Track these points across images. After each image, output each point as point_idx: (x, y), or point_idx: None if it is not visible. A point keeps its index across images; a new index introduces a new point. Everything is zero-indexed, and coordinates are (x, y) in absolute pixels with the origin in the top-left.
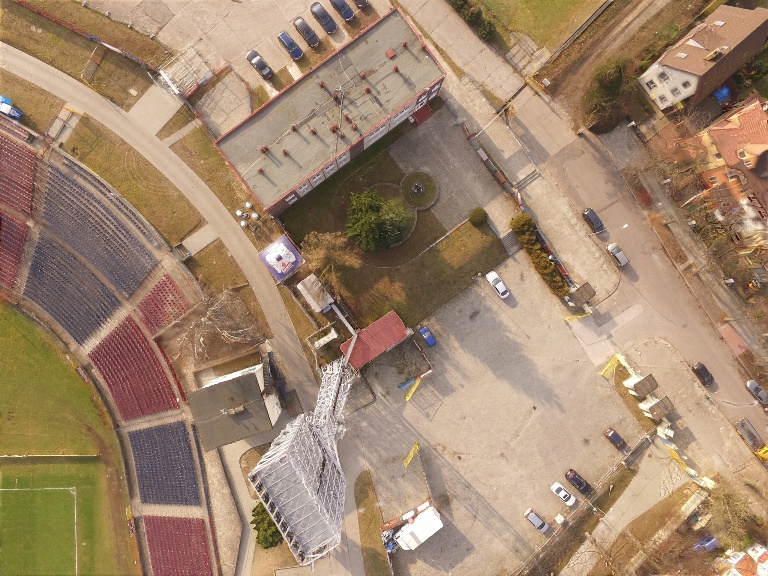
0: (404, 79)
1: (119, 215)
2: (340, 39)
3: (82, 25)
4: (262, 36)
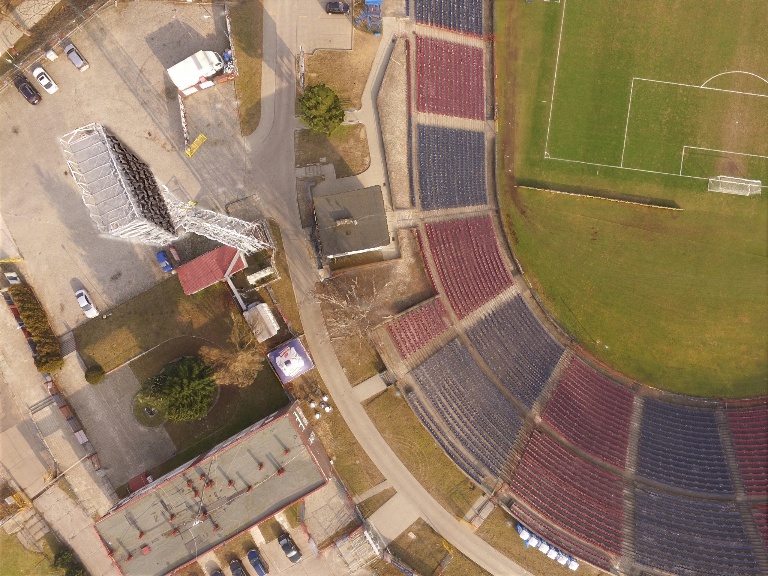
0: (136, 524)
1: (441, 422)
2: (210, 564)
3: None
4: (285, 575)
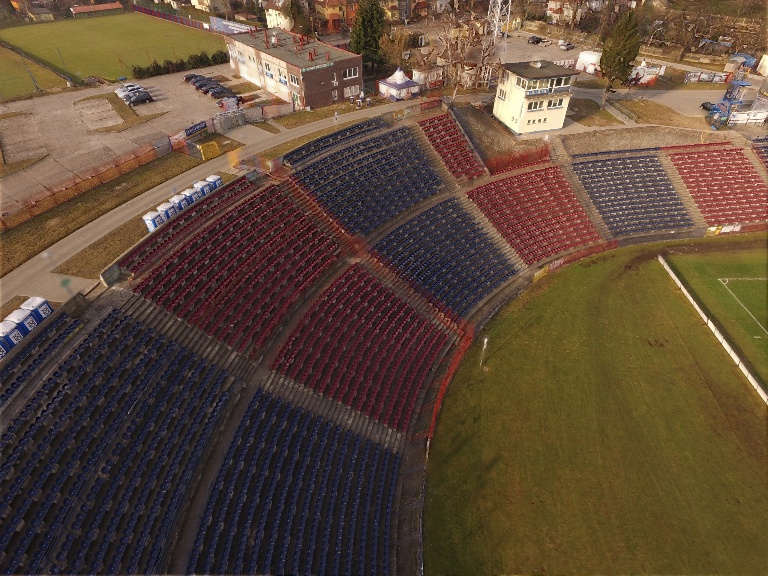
0: None
1: None
2: None
3: (137, 163)
4: None
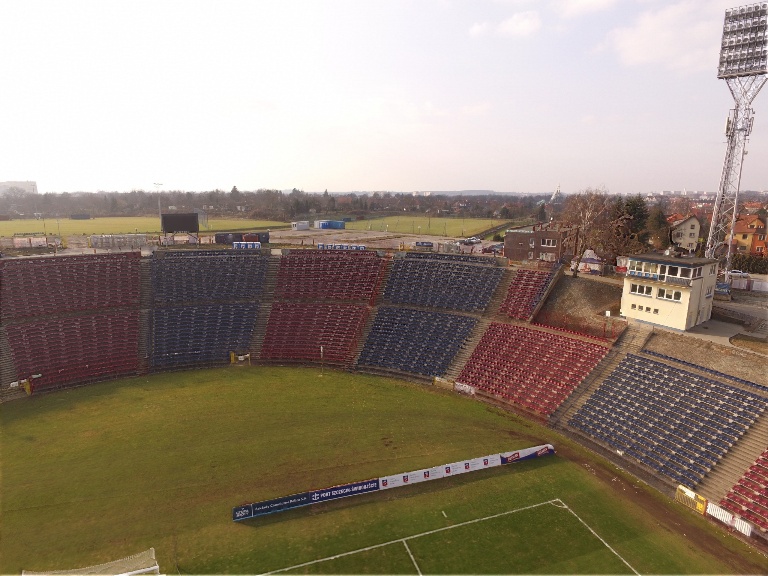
0: None
1: None
2: None
3: None
4: None
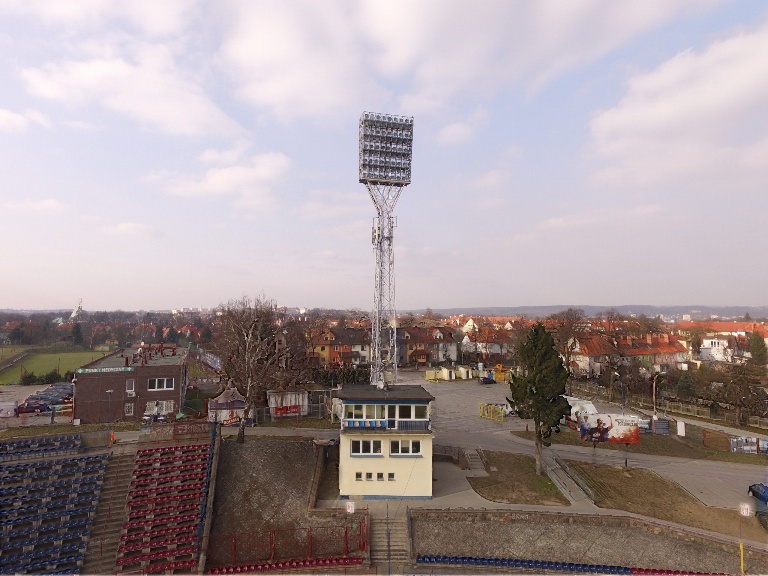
0: None
1: None
2: None
3: None
4: None
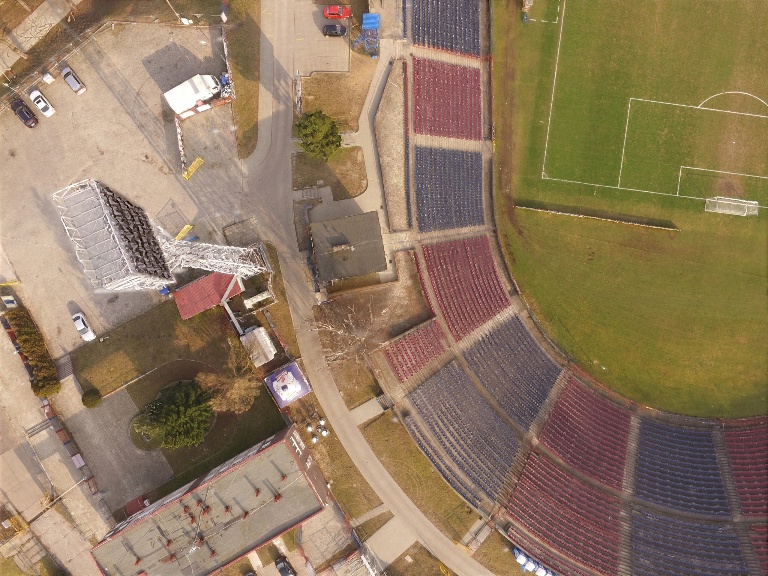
0: (133, 550)
1: (438, 445)
2: None
3: None
4: None
